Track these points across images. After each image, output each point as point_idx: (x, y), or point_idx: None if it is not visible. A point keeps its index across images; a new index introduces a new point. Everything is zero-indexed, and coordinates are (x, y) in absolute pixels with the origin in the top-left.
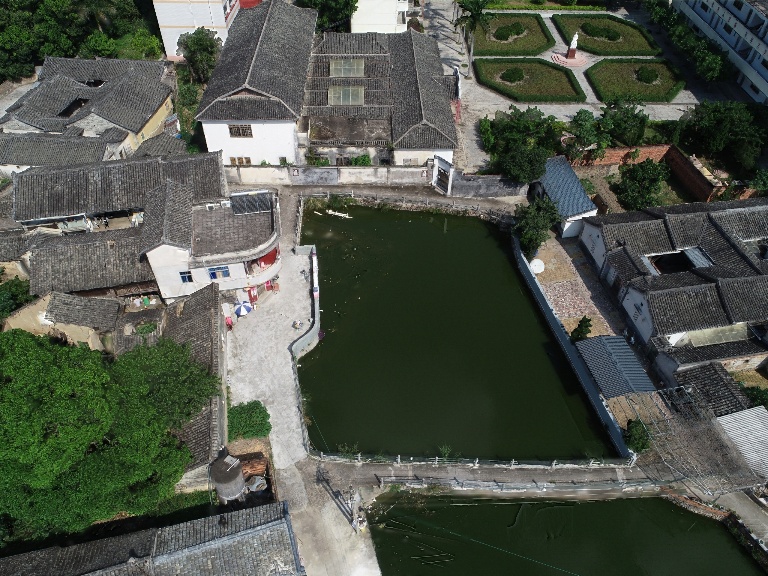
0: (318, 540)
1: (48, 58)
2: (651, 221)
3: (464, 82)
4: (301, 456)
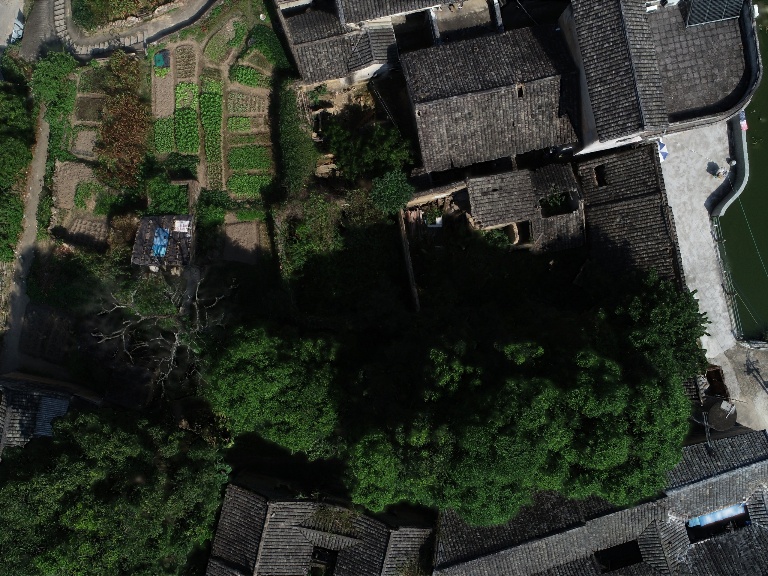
0: (753, 428)
1: None
2: None
3: None
4: (730, 344)
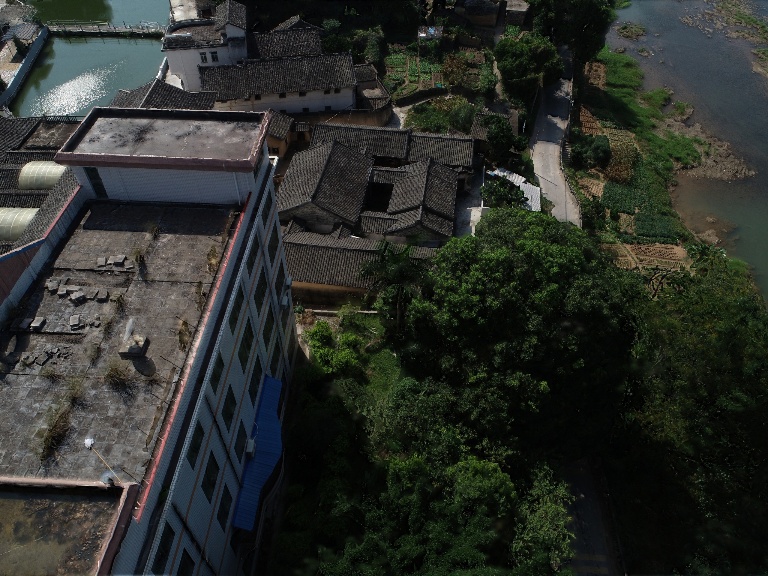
0: None
1: None
2: None
3: None
4: None
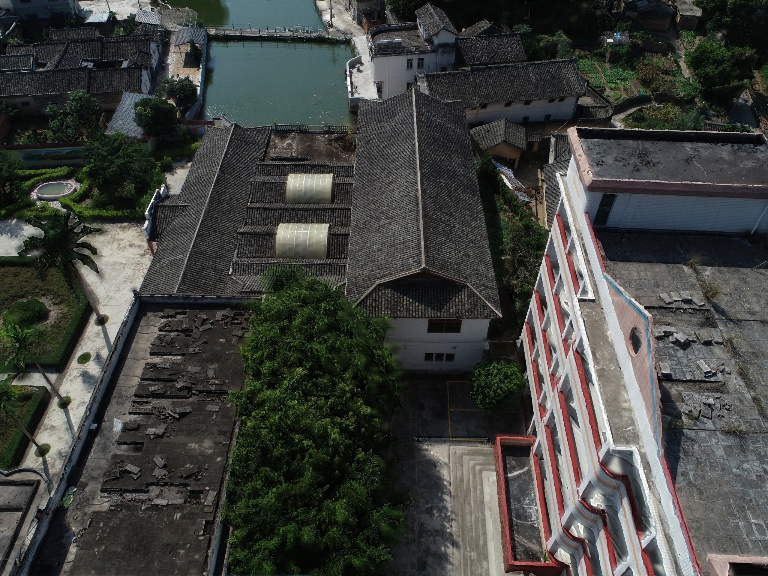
0: None
1: None
2: (100, 69)
3: (115, 308)
4: None
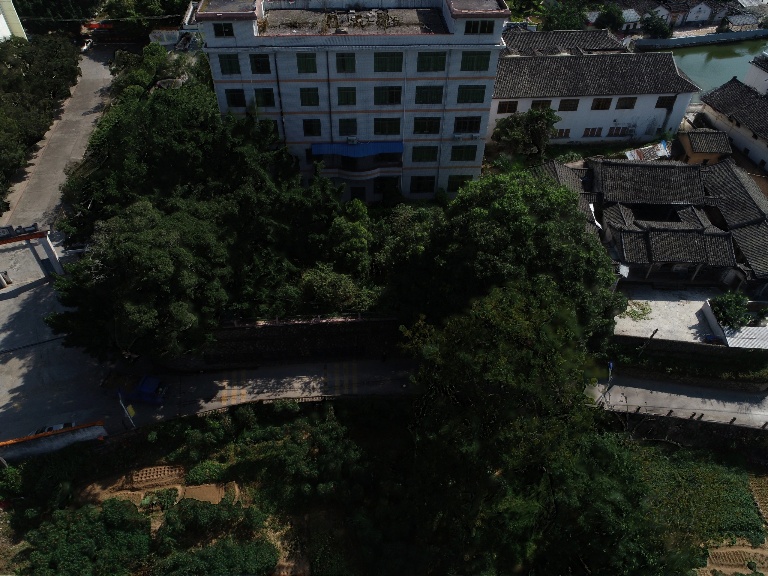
0: None
1: None
2: None
3: None
4: None
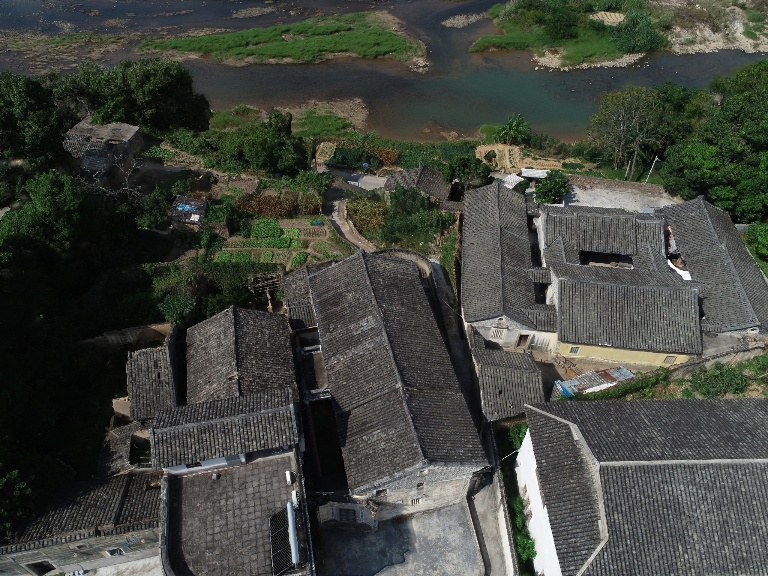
0: None
1: (700, 200)
2: None
3: None
4: None
